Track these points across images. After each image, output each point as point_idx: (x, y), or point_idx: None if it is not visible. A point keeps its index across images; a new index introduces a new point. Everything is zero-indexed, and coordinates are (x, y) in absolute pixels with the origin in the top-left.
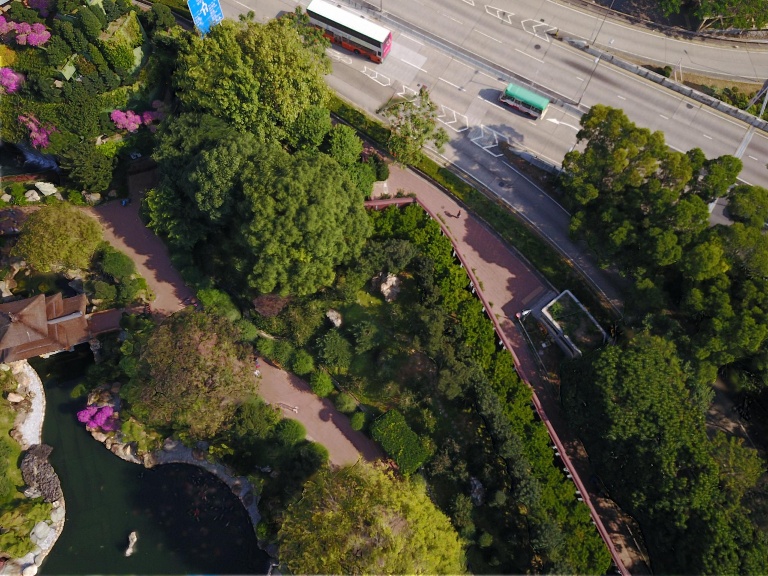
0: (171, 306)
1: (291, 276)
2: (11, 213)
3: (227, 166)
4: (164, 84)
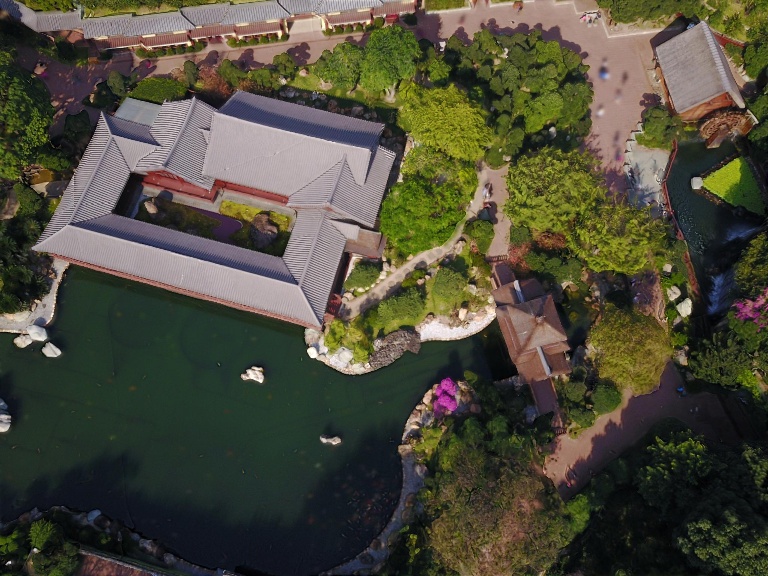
0: (565, 457)
1: None
2: (651, 274)
3: (755, 570)
4: None
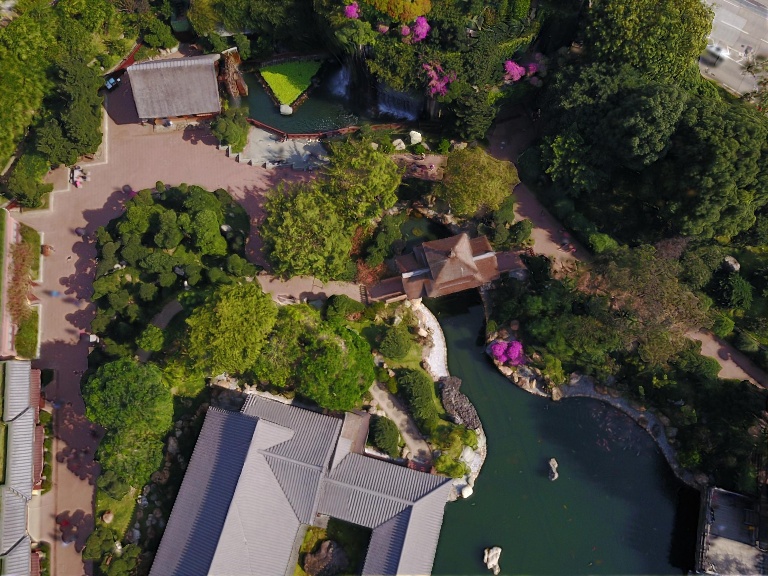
0: (551, 251)
1: (723, 218)
2: None
3: (672, 112)
4: (547, 37)
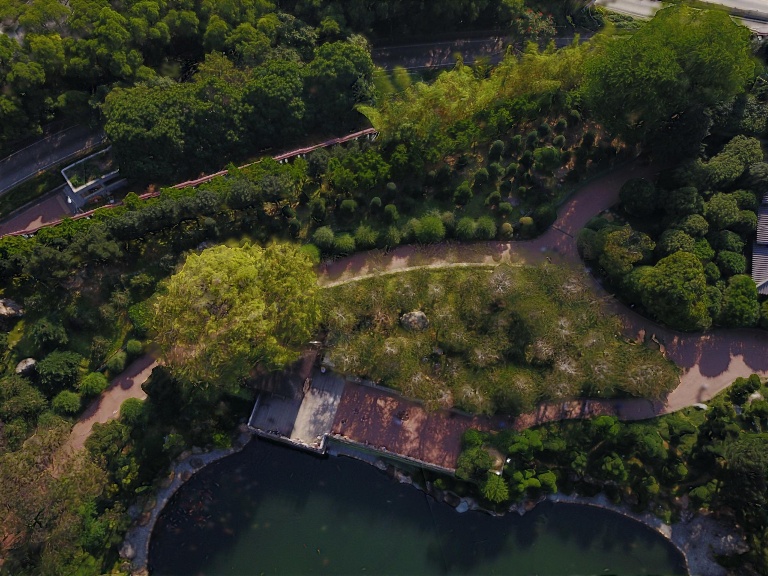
0: None
1: None
2: None
3: None
4: None
